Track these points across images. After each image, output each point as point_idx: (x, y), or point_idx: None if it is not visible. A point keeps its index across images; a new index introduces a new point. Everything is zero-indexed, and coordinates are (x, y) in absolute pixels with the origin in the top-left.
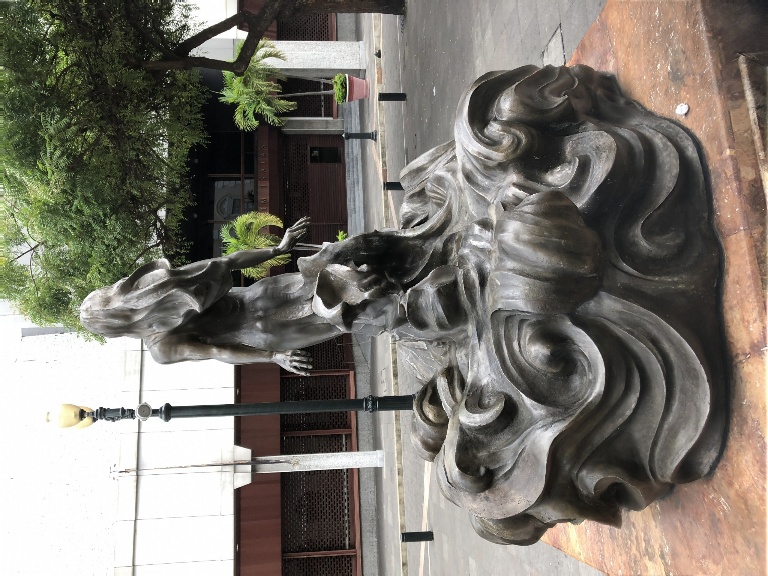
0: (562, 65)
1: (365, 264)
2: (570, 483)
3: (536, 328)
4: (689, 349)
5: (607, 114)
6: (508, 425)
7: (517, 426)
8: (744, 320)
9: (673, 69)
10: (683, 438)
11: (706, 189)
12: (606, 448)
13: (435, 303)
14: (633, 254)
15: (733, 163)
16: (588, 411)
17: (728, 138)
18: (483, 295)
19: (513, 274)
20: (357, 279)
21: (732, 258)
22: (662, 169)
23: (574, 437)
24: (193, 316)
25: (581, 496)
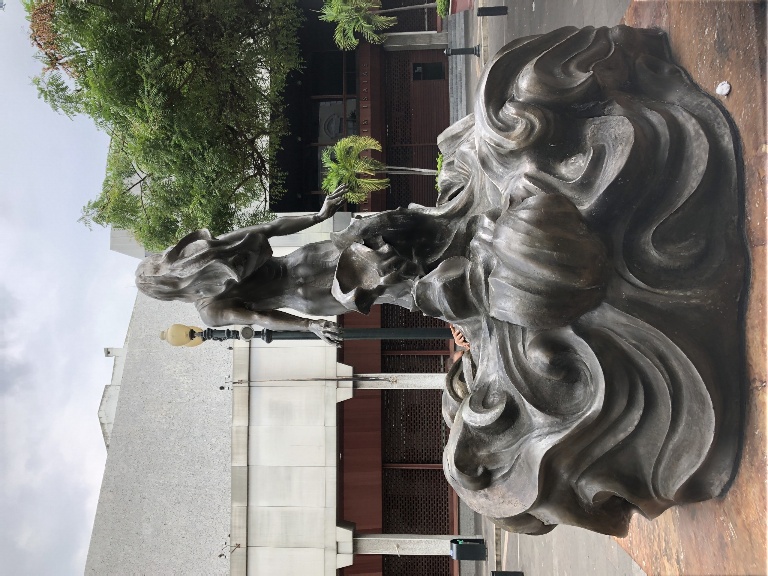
0: (600, 27)
1: (387, 244)
2: (570, 490)
3: (537, 334)
4: (696, 372)
5: (646, 86)
6: (509, 427)
7: (518, 429)
8: (763, 344)
9: (719, 38)
10: (685, 463)
11: (738, 188)
12: (608, 460)
13: (441, 298)
14: (644, 262)
15: (767, 162)
16: (584, 426)
17: (765, 131)
18: (488, 293)
19: (505, 283)
20: (377, 260)
21: (757, 272)
22: (689, 163)
23: (570, 449)
24: (237, 282)
25: (581, 504)
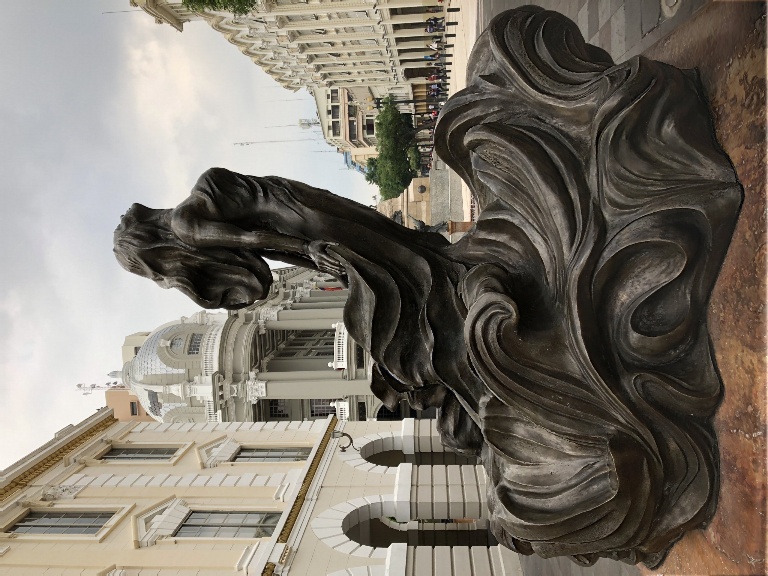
0: None
1: None
2: None
3: None
4: None
5: None
6: None
7: None
8: None
9: None
10: None
11: None
12: None
13: None
14: None
15: None
16: None
17: None
18: None
19: None
20: None
21: None
22: None
23: None
24: None
25: None
